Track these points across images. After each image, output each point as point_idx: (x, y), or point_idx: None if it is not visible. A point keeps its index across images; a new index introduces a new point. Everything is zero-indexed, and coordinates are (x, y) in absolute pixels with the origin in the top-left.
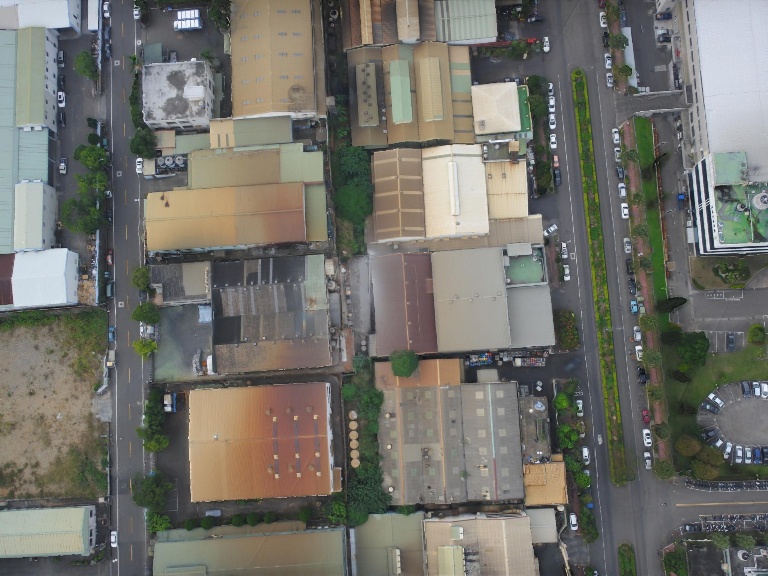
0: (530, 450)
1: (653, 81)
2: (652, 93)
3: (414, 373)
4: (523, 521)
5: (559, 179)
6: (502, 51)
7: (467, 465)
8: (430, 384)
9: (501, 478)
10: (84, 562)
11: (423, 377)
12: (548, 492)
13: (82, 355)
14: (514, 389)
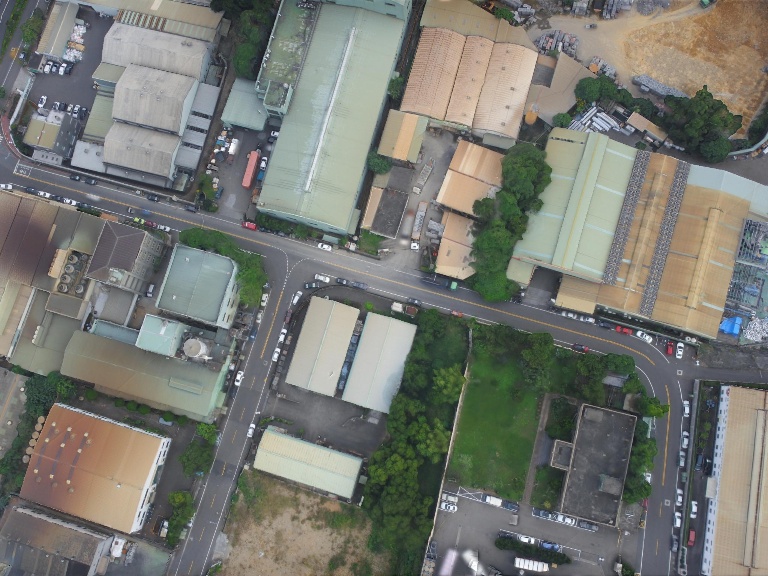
0: None
1: None
2: None
3: None
4: None
5: None
6: None
7: None
8: None
9: None
10: (280, 421)
11: None
12: None
13: None
14: None
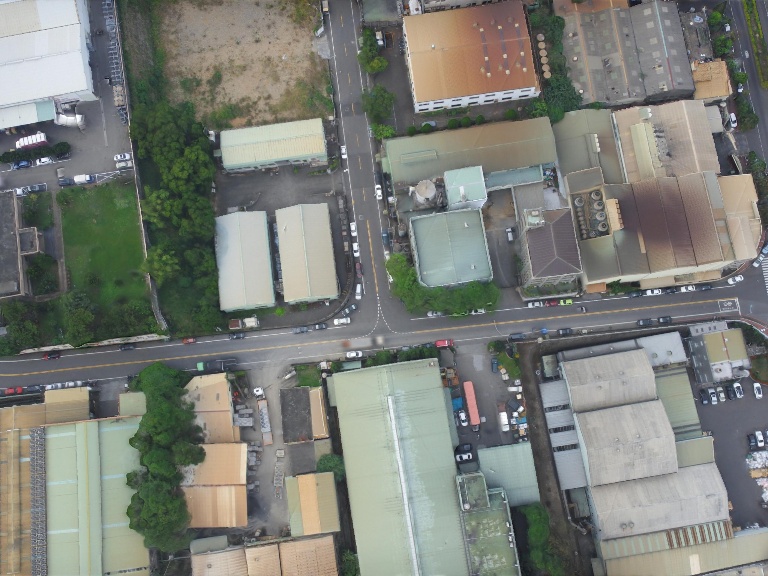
0: (695, 54)
1: None
2: None
3: (588, 2)
4: (699, 102)
5: None
6: None
7: (643, 69)
8: (604, 8)
9: (675, 73)
10: (320, 171)
11: (596, 4)
12: (713, 87)
13: (299, 6)
14: (675, 7)
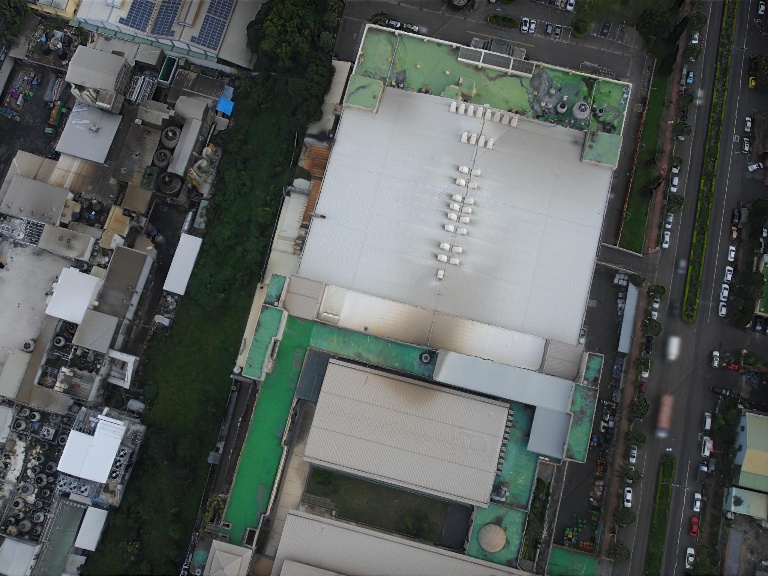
0: None
1: (602, 292)
2: (622, 269)
3: None
4: None
5: (736, 213)
6: (766, 367)
7: None
8: None
9: None
10: None
11: None
12: None
13: None
14: None
